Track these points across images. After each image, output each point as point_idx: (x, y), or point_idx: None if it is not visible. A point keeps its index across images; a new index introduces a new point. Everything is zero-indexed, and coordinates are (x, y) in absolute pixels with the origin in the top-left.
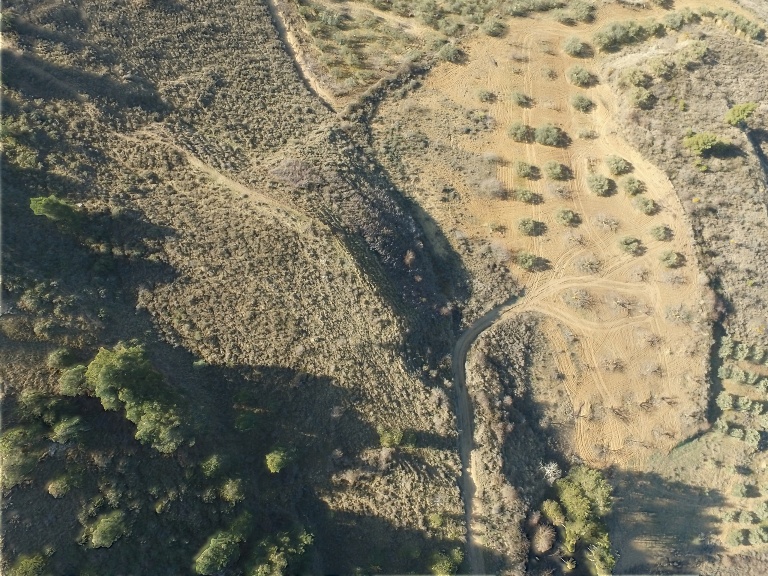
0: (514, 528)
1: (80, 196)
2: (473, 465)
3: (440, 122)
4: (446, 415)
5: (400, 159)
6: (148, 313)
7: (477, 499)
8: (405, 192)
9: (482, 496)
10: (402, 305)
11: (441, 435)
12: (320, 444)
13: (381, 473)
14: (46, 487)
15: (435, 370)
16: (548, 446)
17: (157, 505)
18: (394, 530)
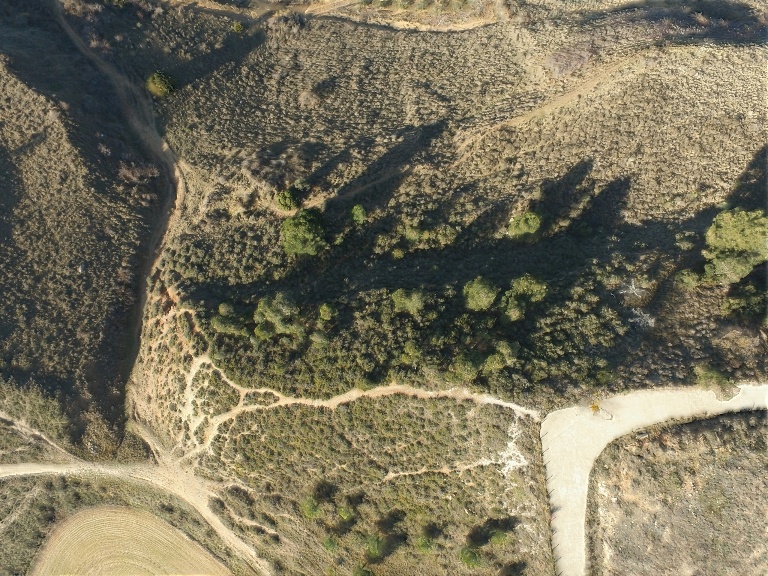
0: None
1: (505, 215)
2: None
3: None
4: None
5: None
6: (646, 221)
7: None
8: (611, 5)
9: None
10: (747, 40)
11: None
12: None
13: None
14: None
15: None
16: None
17: None
18: None
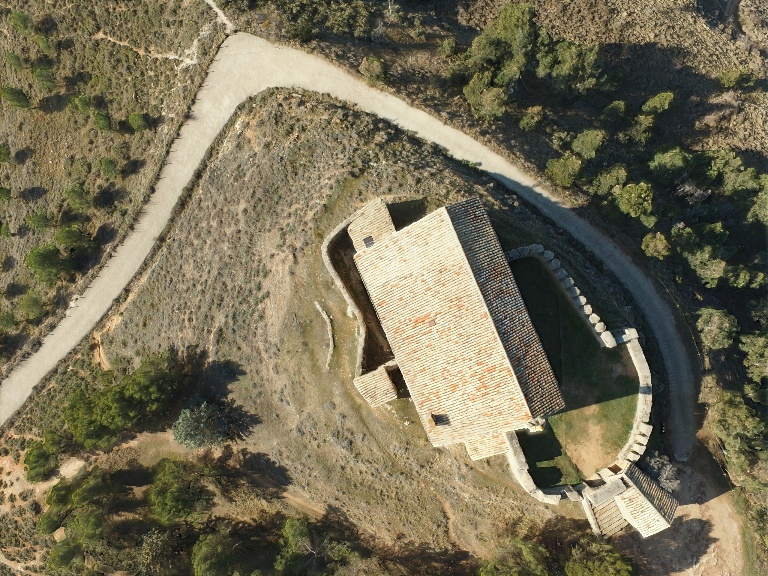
0: None
1: None
2: None
3: None
4: (759, 60)
5: None
6: (473, 29)
7: None
8: None
9: None
10: None
11: (762, 78)
12: None
13: (737, 109)
14: (512, 127)
15: (729, 28)
16: None
17: None
18: (766, 159)
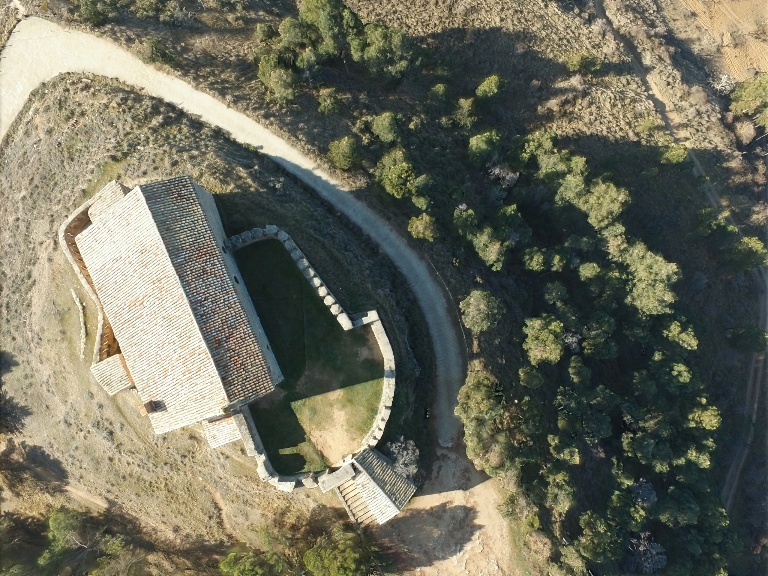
0: (714, 127)
1: None
2: (653, 87)
3: None
4: (614, 44)
5: None
6: None
7: (670, 113)
8: None
9: (674, 108)
10: None
11: (616, 63)
12: (515, 84)
13: (581, 93)
14: (311, 110)
15: (586, 13)
16: (707, 74)
17: (407, 126)
18: (611, 143)
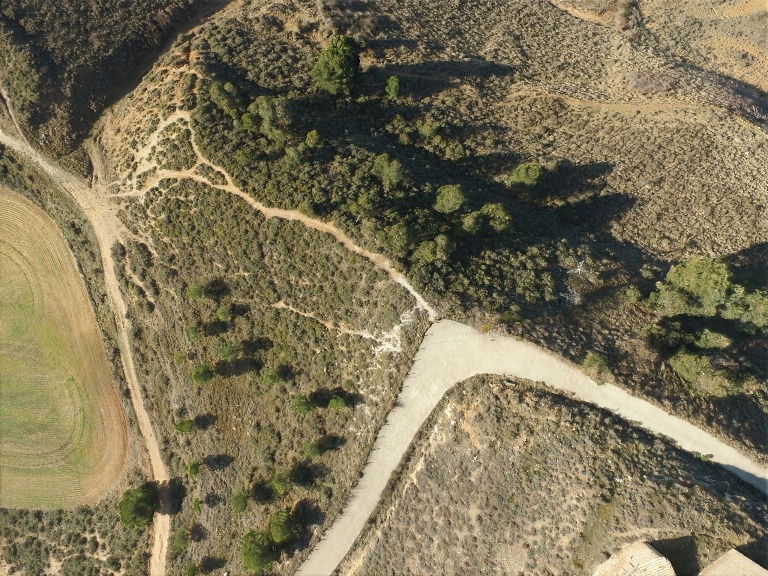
0: None
1: (514, 166)
2: None
3: (696, 1)
4: None
5: (689, 45)
6: (628, 243)
7: None
8: (714, 71)
9: None
10: None
11: None
12: None
13: None
14: None
15: None
16: None
17: None
18: None
